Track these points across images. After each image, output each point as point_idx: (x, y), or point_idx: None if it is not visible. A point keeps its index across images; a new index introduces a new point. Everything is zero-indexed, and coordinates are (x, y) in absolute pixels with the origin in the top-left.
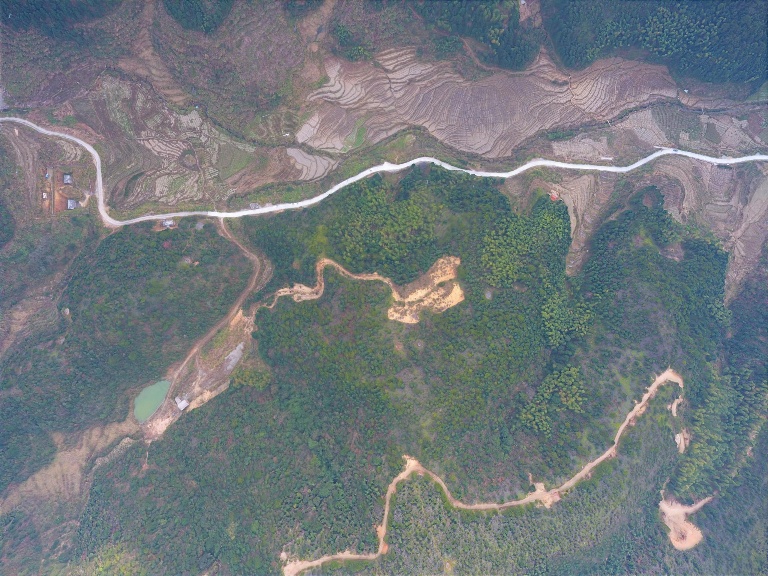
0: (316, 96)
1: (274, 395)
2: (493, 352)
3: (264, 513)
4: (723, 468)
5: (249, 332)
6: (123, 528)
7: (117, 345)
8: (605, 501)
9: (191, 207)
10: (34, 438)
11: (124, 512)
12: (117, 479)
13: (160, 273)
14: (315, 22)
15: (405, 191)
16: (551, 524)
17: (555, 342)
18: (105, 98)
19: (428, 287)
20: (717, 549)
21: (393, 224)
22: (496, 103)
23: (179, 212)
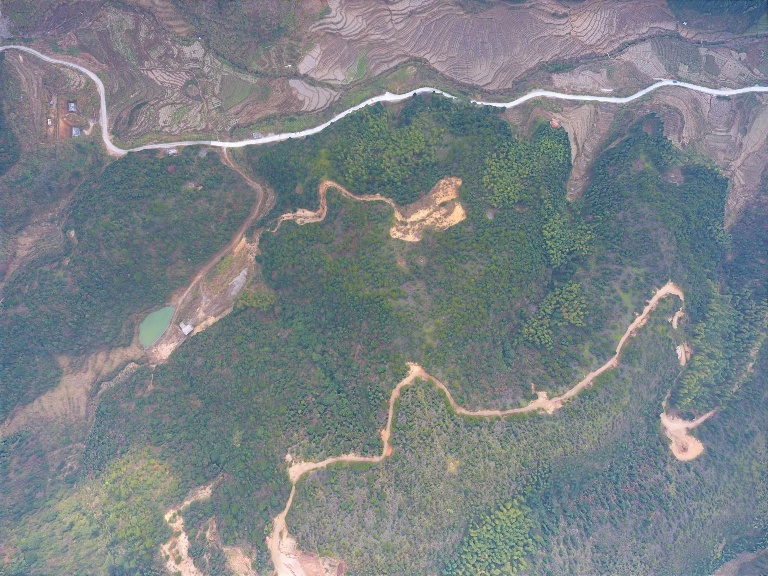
0: (318, 27)
1: (278, 315)
2: (495, 264)
3: (269, 419)
4: (724, 383)
5: (252, 258)
6: (129, 442)
7: (122, 264)
8: (607, 407)
9: (194, 137)
10: (40, 360)
11: (130, 427)
12: (123, 399)
13: (164, 195)
14: None
15: (406, 118)
16: (553, 428)
17: (556, 261)
18: (108, 28)
19: (430, 207)
20: (718, 459)
21: (395, 148)
22: (496, 35)
23: (182, 141)
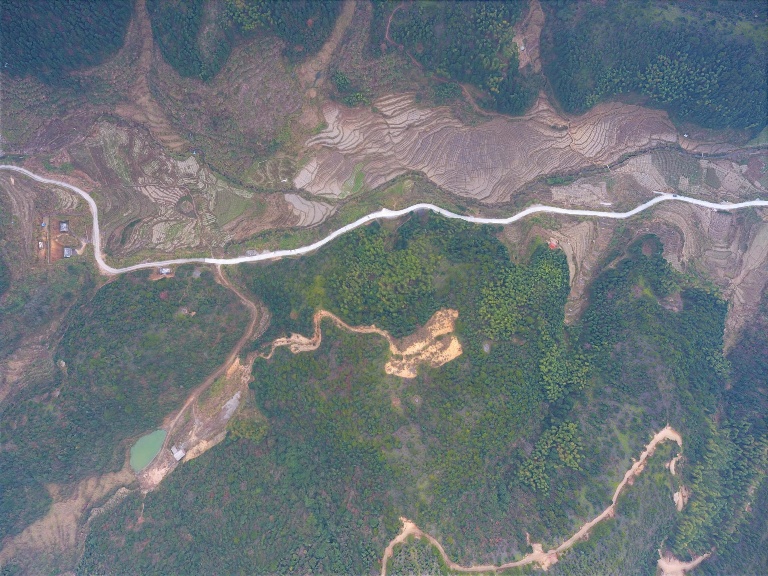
0: (314, 142)
1: (271, 448)
2: (491, 411)
3: (260, 575)
4: (721, 524)
5: (246, 381)
6: None
7: (113, 399)
8: (603, 564)
9: (188, 254)
10: (29, 490)
11: (119, 568)
12: (113, 532)
13: (156, 325)
14: (313, 68)
15: (403, 239)
16: None
17: (553, 396)
18: (102, 144)
19: (426, 340)
20: None
21: (391, 274)
22: (495, 148)
23: (176, 259)
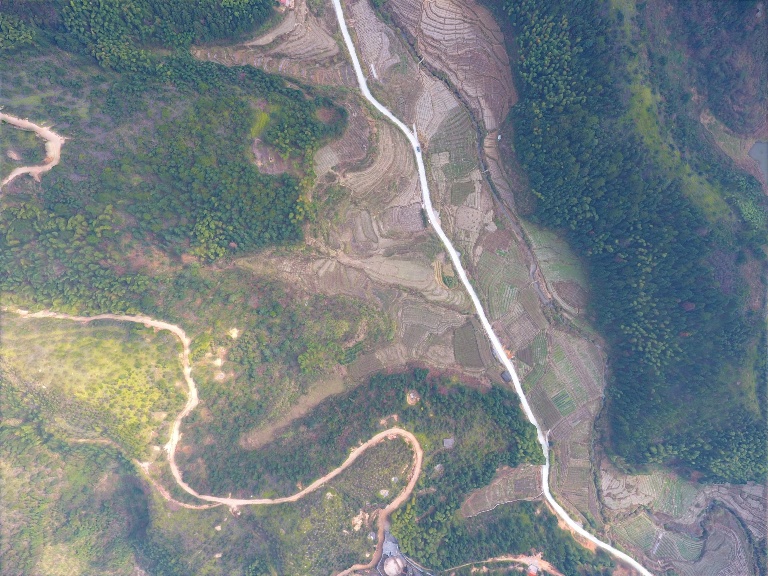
0: None
1: None
2: None
3: None
4: None
5: None
6: None
7: None
8: None
9: None
10: None
11: None
12: None
13: None
14: None
15: None
16: None
17: (68, 20)
18: None
19: None
20: None
21: None
22: None
23: None
